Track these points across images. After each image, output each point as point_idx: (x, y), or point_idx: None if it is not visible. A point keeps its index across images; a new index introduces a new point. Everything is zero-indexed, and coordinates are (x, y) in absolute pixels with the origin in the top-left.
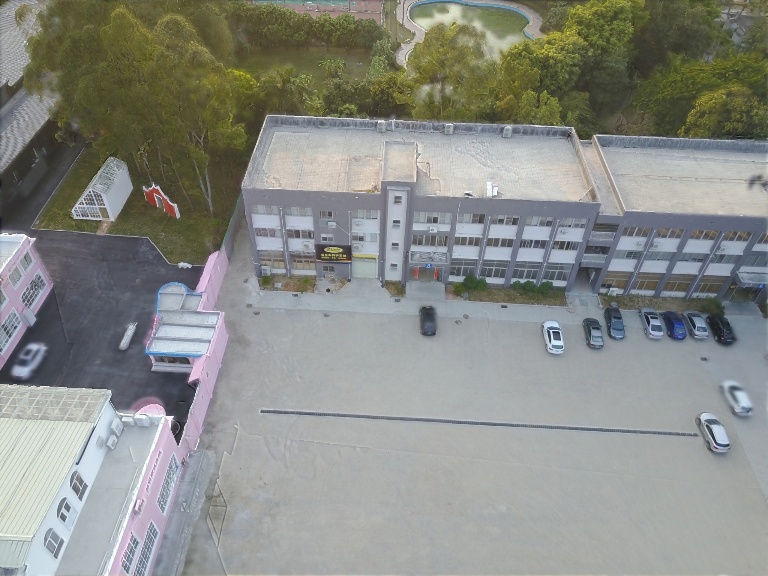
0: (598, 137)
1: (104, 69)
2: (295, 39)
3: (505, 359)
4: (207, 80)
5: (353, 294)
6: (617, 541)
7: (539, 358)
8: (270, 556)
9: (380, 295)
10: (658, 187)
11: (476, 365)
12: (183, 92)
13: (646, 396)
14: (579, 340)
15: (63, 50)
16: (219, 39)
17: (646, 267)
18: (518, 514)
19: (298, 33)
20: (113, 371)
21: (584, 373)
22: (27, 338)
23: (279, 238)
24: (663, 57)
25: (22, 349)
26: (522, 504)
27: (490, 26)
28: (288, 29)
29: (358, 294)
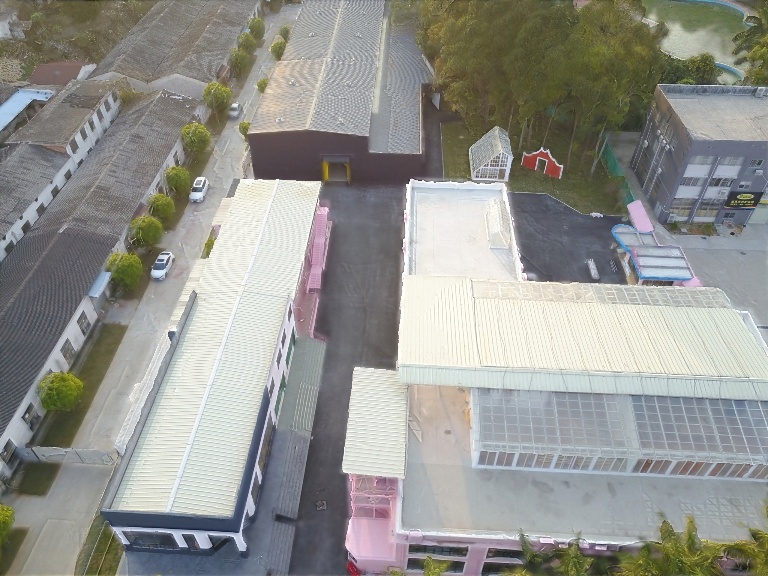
0: None
1: (579, 40)
2: None
3: None
4: None
5: (754, 237)
6: None
7: None
8: None
9: None
10: None
11: None
12: (657, 57)
13: None
14: None
15: (533, 26)
16: None
17: None
18: None
19: None
20: None
21: None
22: None
23: (699, 187)
24: None
25: None
26: None
27: (709, 18)
28: None
29: (758, 237)
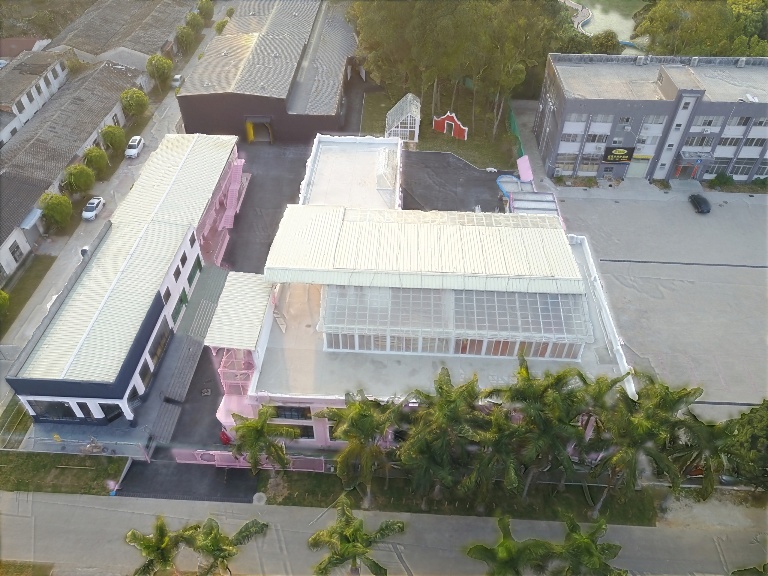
0: None
1: (464, 10)
2: None
3: None
4: None
5: (630, 189)
6: None
7: None
8: (658, 340)
9: (651, 189)
10: None
11: (748, 232)
12: (530, 24)
13: None
14: None
15: None
16: None
17: None
18: None
19: None
20: None
21: None
22: None
23: (578, 143)
24: None
25: None
26: None
27: (637, 4)
28: None
29: (634, 189)
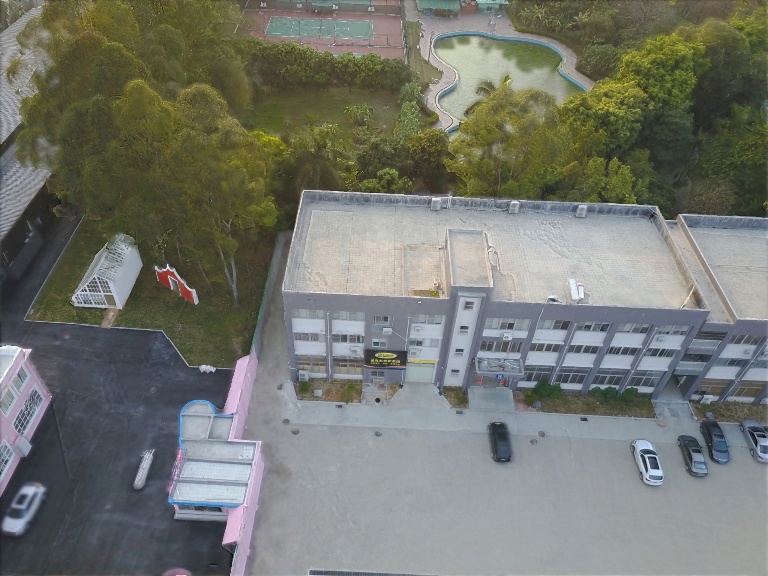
0: (684, 217)
1: (117, 150)
2: (316, 81)
3: (594, 492)
4: (239, 159)
5: (407, 404)
6: None
7: (634, 490)
8: None
9: (438, 405)
10: (763, 282)
11: (561, 501)
12: (214, 180)
13: (766, 542)
14: (676, 464)
15: (66, 124)
16: (238, 88)
17: (750, 375)
18: None
19: (319, 74)
20: (127, 520)
21: (689, 510)
22: (20, 473)
23: (322, 342)
24: (721, 106)
25: (14, 489)
26: None
27: (521, 63)
28: (308, 70)
29: (413, 404)
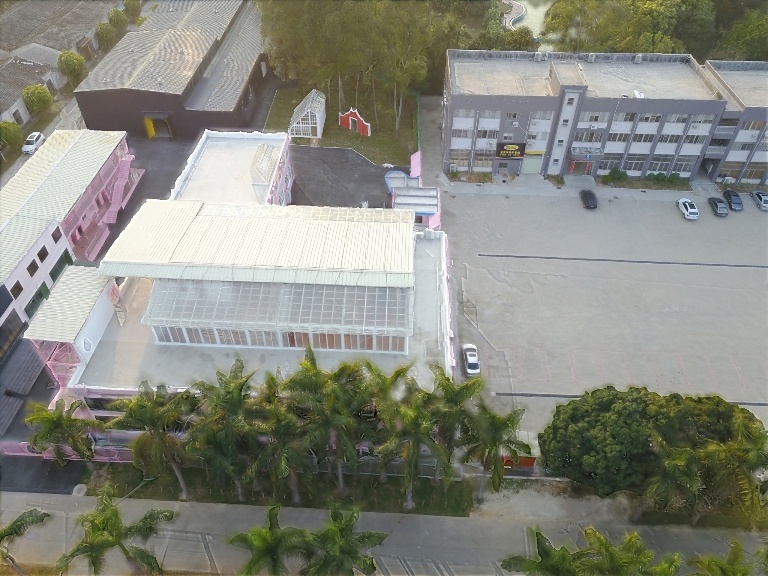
0: (710, 62)
1: (349, 6)
2: None
3: (653, 224)
4: None
5: (523, 184)
6: (765, 327)
7: (679, 223)
8: (517, 334)
9: (544, 185)
10: (765, 95)
11: (632, 227)
12: (413, 20)
13: (767, 245)
14: (707, 212)
15: None
16: None
17: (756, 157)
18: (688, 312)
19: None
20: None
21: (716, 232)
22: None
23: (469, 139)
24: (737, 15)
25: None
26: (690, 306)
27: None
28: None
29: (527, 184)
